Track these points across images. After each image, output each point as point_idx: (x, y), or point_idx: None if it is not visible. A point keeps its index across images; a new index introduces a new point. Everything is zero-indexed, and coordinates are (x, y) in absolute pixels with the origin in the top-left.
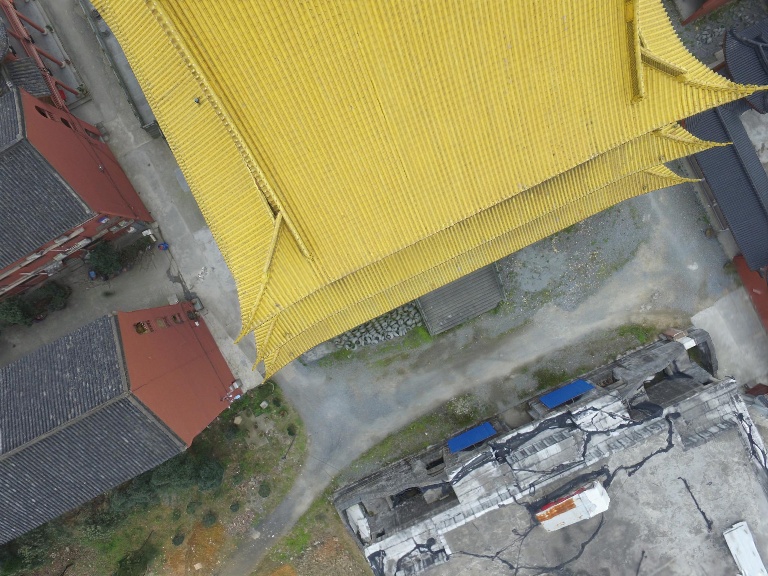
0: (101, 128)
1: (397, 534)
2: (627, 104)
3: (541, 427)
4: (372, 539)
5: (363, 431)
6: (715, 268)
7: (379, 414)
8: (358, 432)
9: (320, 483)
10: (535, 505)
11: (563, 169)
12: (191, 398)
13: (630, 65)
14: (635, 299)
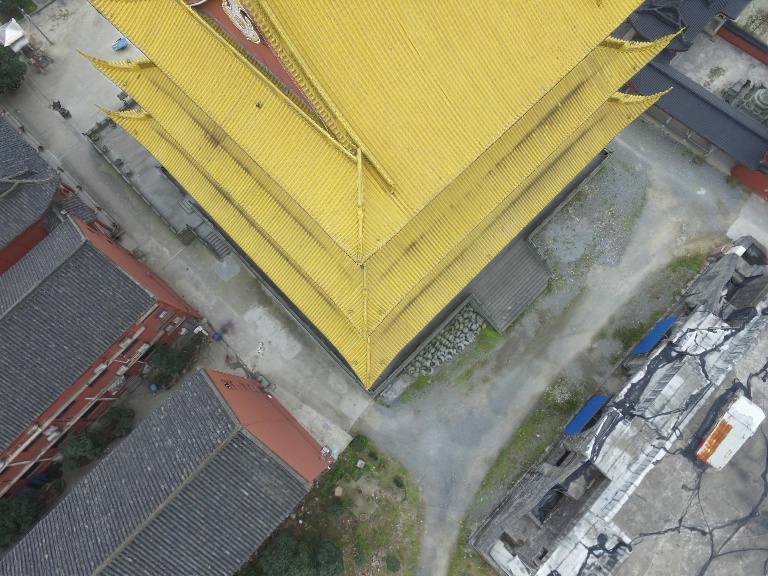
0: (137, 252)
1: (561, 544)
2: (594, 7)
3: (650, 369)
4: (536, 564)
5: (473, 456)
6: (720, 186)
7: (482, 432)
8: (468, 459)
9: (450, 535)
10: (690, 449)
11: (569, 68)
12: (293, 449)
13: None
14: (668, 235)
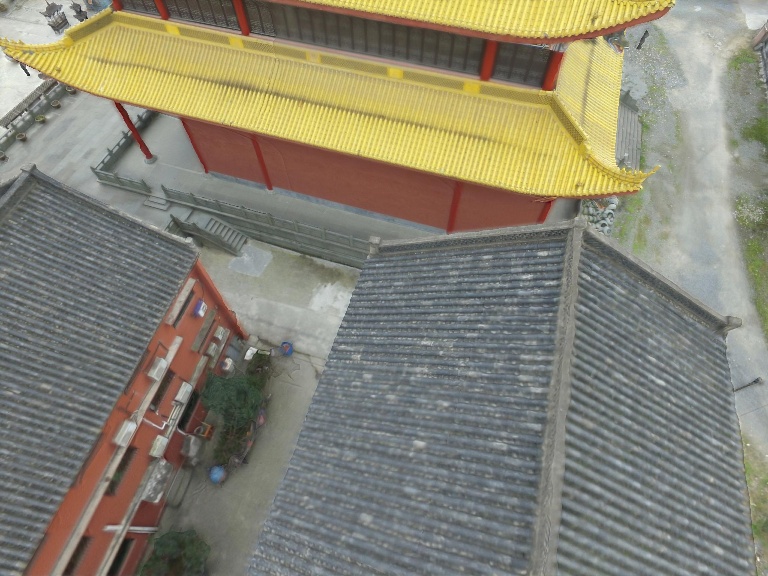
0: None
1: None
2: None
3: None
4: None
5: None
6: (708, 1)
7: (712, 292)
8: None
9: None
10: None
11: None
12: None
13: None
14: (705, 46)
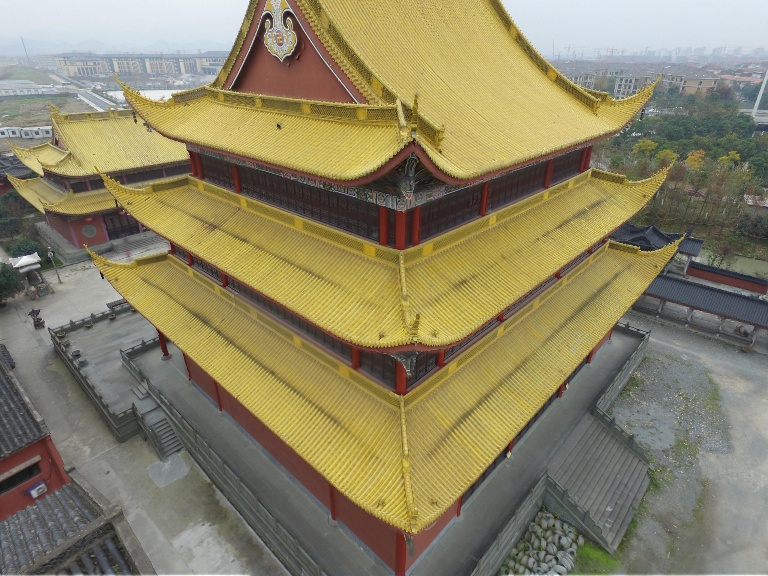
0: None
1: None
2: None
3: None
4: None
5: None
6: None
7: None
8: None
9: None
10: None
11: None
12: None
13: (575, 97)
14: None
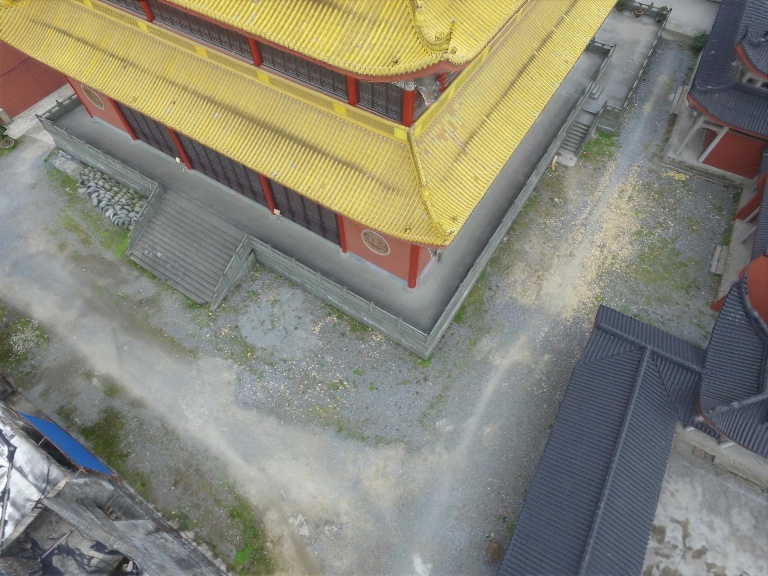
0: None
1: None
2: None
3: None
4: None
5: None
6: None
7: None
8: None
9: None
10: None
11: None
12: None
13: None
14: (307, 495)
